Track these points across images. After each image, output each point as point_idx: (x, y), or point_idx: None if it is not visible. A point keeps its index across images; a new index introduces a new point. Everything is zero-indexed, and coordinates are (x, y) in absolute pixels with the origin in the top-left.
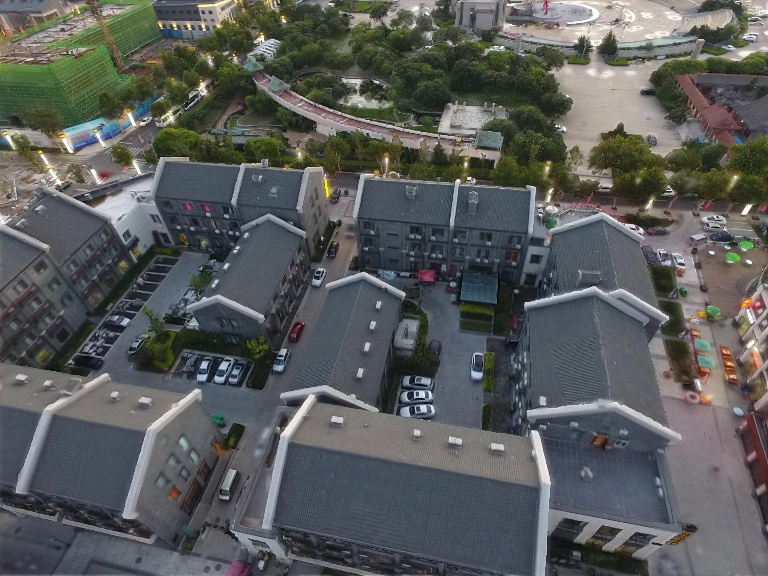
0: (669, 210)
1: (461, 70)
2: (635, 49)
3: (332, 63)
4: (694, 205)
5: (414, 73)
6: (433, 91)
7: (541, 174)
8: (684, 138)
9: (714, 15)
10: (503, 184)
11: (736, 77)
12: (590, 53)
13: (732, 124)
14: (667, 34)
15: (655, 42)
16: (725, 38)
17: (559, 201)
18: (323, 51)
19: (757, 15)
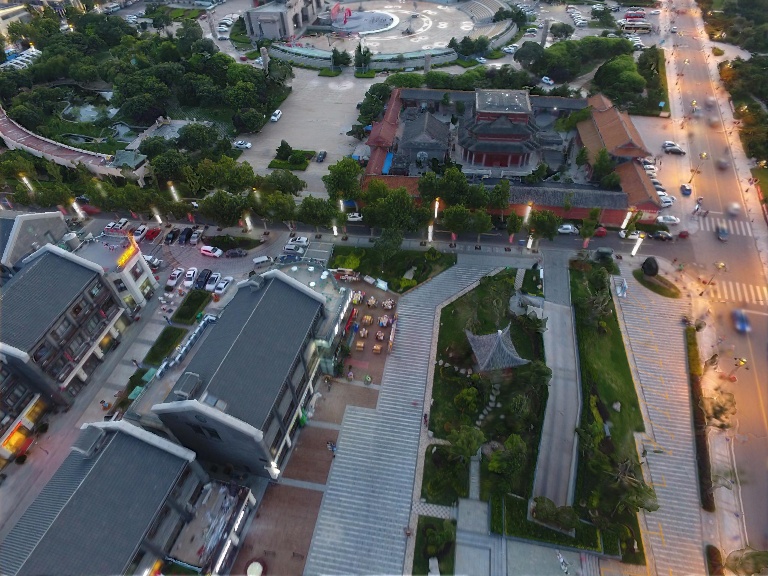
0: (269, 231)
1: (185, 84)
2: (388, 61)
3: (74, 75)
4: (300, 225)
5: (133, 87)
6: (137, 106)
7: (120, 197)
8: (355, 154)
9: (497, 26)
10: (94, 206)
11: (435, 92)
12: (340, 65)
13: (385, 141)
14: (444, 45)
15: (418, 53)
16: (478, 50)
17: (170, 222)
18: (70, 63)
19: (538, 26)
